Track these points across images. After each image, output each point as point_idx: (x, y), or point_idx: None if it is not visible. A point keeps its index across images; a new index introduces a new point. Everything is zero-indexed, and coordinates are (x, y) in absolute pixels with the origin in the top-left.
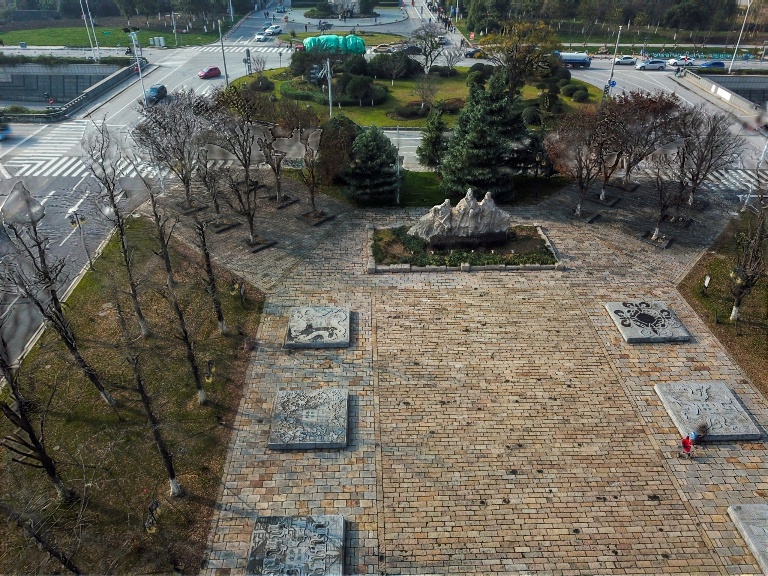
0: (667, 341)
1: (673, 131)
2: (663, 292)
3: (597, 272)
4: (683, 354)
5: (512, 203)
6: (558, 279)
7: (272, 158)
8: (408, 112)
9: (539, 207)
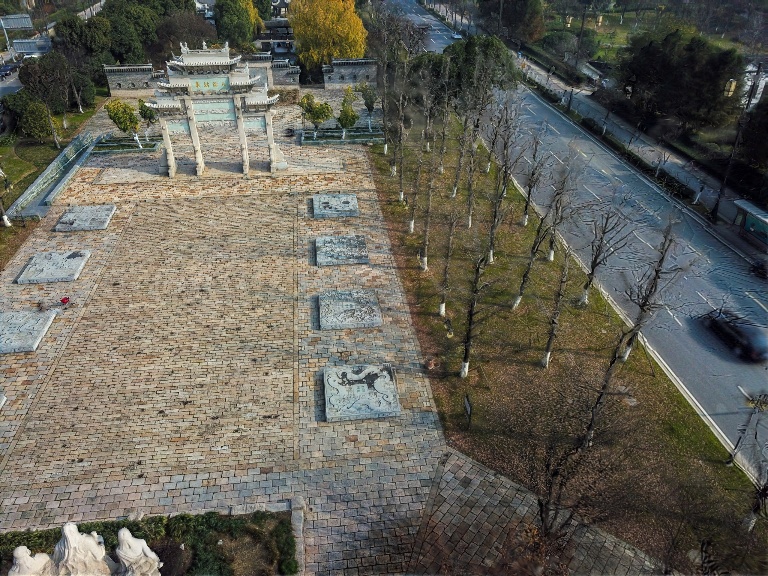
0: None
1: None
2: None
3: None
4: None
5: None
6: None
7: None
8: None
9: None
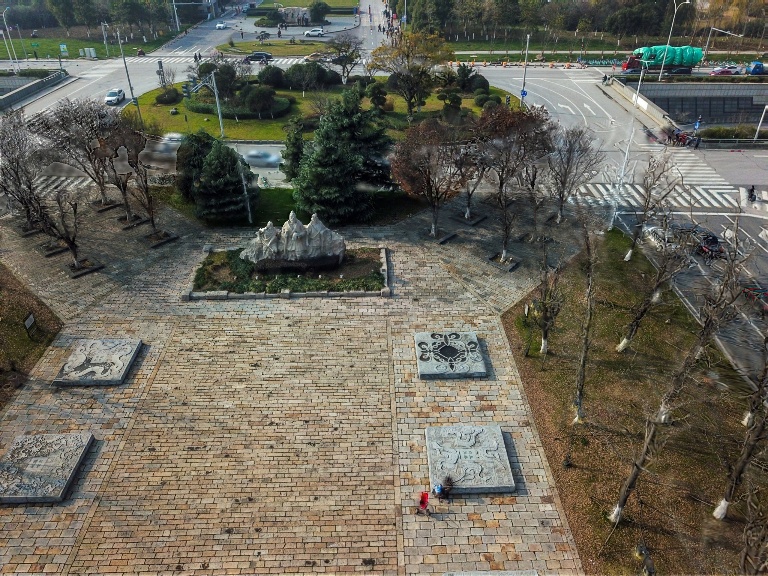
0: (463, 377)
1: (541, 146)
2: (484, 321)
3: (424, 299)
4: (475, 392)
5: (369, 222)
6: (379, 307)
7: (117, 177)
8: (304, 125)
9: (396, 227)
